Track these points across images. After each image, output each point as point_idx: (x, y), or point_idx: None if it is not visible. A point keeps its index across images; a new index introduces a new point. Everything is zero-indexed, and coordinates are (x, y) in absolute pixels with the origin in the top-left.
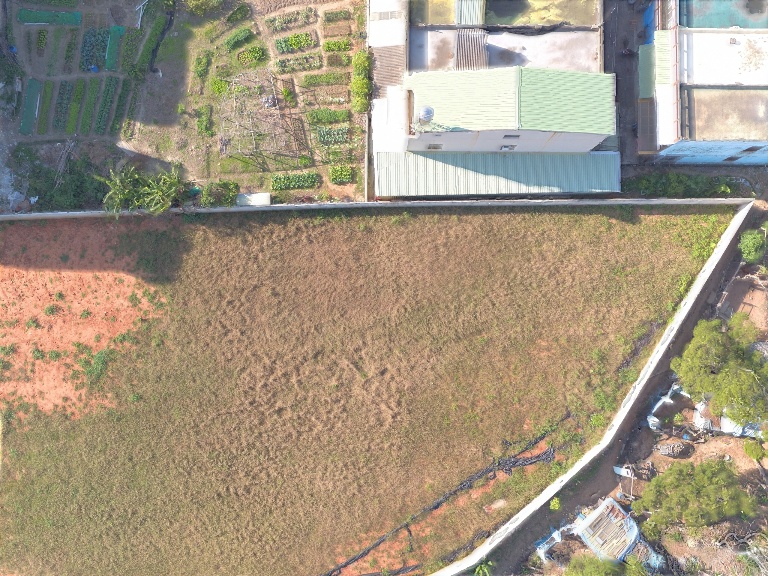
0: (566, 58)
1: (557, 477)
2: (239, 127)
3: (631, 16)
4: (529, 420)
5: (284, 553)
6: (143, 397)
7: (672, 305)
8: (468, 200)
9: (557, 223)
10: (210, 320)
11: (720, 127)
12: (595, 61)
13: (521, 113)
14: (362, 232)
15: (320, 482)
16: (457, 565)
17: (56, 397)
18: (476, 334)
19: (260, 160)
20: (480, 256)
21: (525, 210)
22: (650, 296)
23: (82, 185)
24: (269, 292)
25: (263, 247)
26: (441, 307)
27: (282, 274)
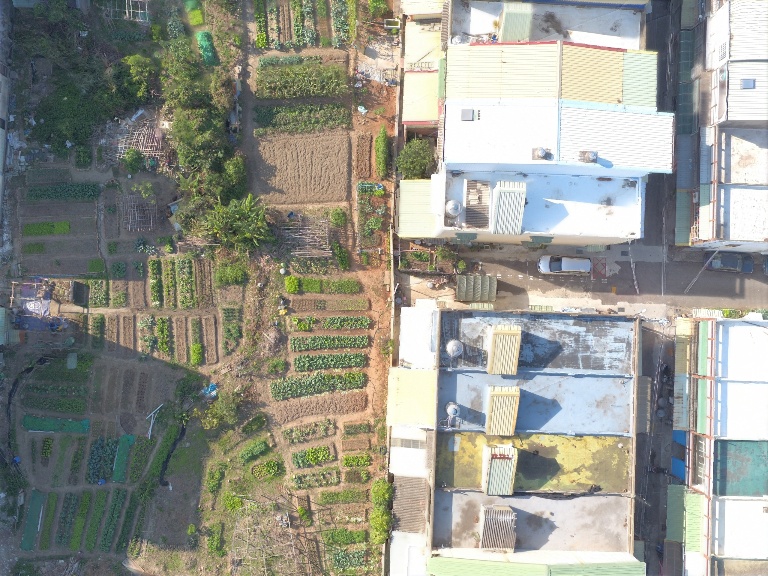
0: (594, 524)
1: None
2: (251, 547)
3: (659, 428)
4: None
5: None
6: None
7: None
8: None
9: None
10: None
11: None
12: (624, 528)
13: None
14: None
15: None
16: None
17: None
18: None
19: None
20: None
21: None
22: None
23: None
24: None
25: None
26: None
27: None
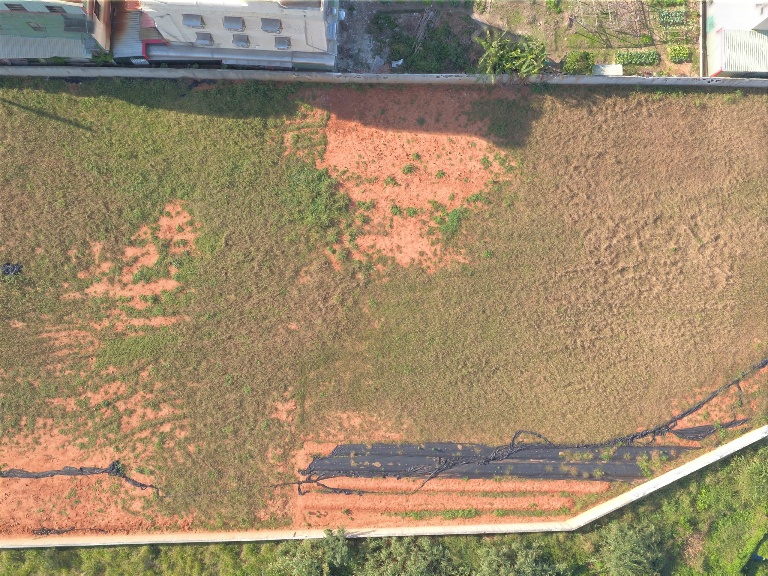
0: None
1: None
2: (584, 5)
3: None
4: None
5: (626, 404)
6: (495, 254)
7: None
8: None
9: None
10: (558, 184)
11: None
12: None
13: None
14: (696, 108)
15: (660, 338)
16: None
17: (413, 251)
18: None
19: (603, 37)
20: None
21: None
22: None
23: (440, 52)
24: (614, 159)
25: (606, 118)
26: None
27: (624, 144)
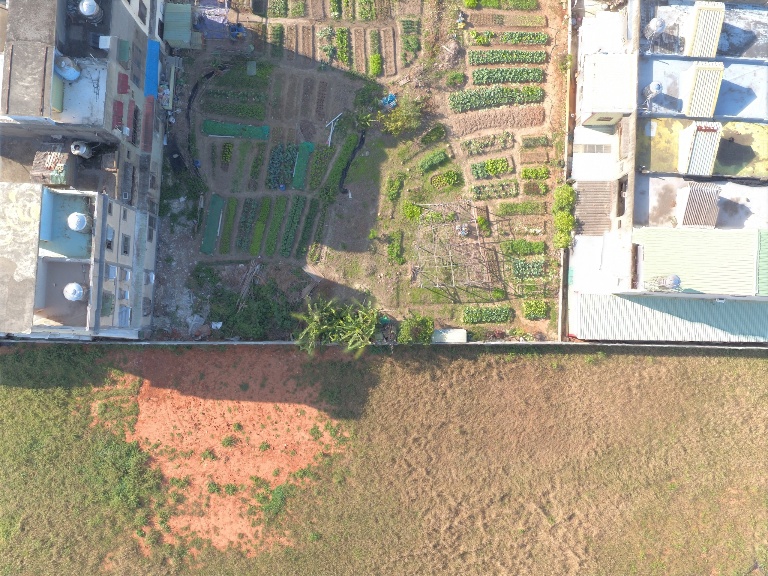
0: None
1: None
2: (431, 255)
3: None
4: (716, 571)
5: None
6: (323, 536)
7: None
8: (668, 344)
9: (751, 368)
10: (395, 457)
11: None
12: None
13: (759, 279)
14: (554, 370)
15: None
16: None
17: (232, 533)
18: (666, 480)
19: (451, 291)
20: (673, 400)
21: (720, 353)
22: None
23: (266, 311)
24: (457, 431)
25: (452, 382)
26: (632, 451)
27: (470, 411)
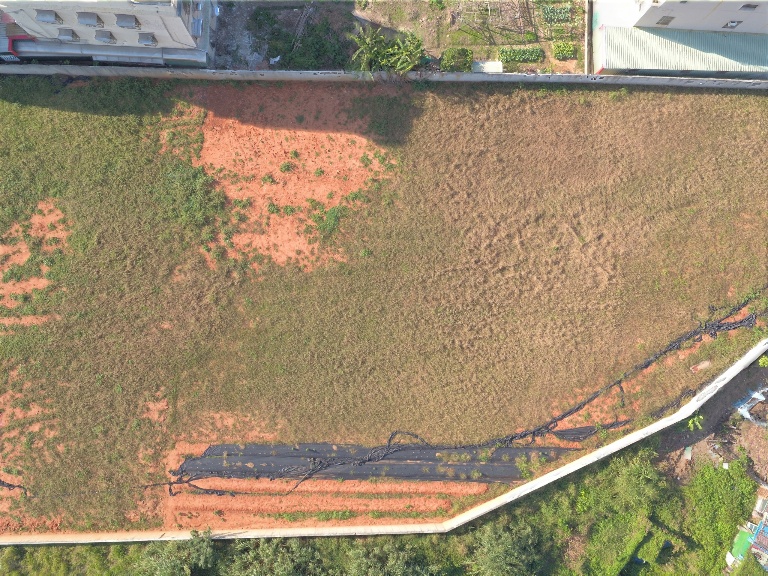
0: None
1: (759, 341)
2: (467, 2)
3: None
4: (733, 288)
5: (505, 405)
6: (373, 252)
7: None
8: (685, 77)
9: (760, 106)
10: (438, 182)
11: None
12: None
13: None
14: (581, 106)
15: (540, 338)
16: (667, 420)
17: (290, 250)
18: (685, 205)
19: (487, 34)
20: (690, 133)
21: (732, 92)
22: None
23: (319, 48)
24: (495, 157)
25: (489, 115)
26: (654, 179)
27: (506, 142)
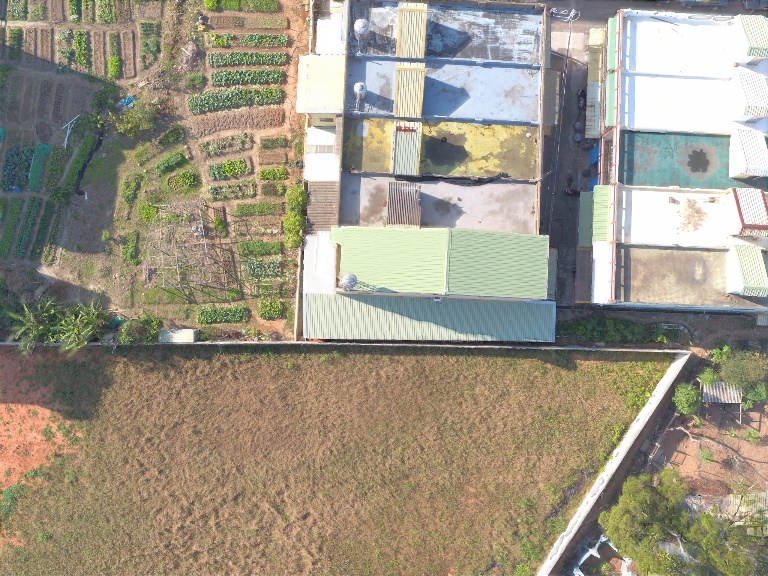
0: (502, 211)
1: None
2: (166, 256)
3: (576, 154)
4: (454, 569)
5: None
6: (53, 536)
7: (604, 455)
8: (399, 344)
9: (491, 366)
10: (127, 457)
11: (655, 288)
12: (531, 215)
13: (449, 277)
14: (290, 370)
15: None
16: None
17: None
18: (403, 479)
19: (187, 291)
20: (410, 399)
21: (459, 352)
22: (582, 445)
23: None
24: (190, 430)
25: (186, 382)
26: (368, 450)
27: (205, 411)
